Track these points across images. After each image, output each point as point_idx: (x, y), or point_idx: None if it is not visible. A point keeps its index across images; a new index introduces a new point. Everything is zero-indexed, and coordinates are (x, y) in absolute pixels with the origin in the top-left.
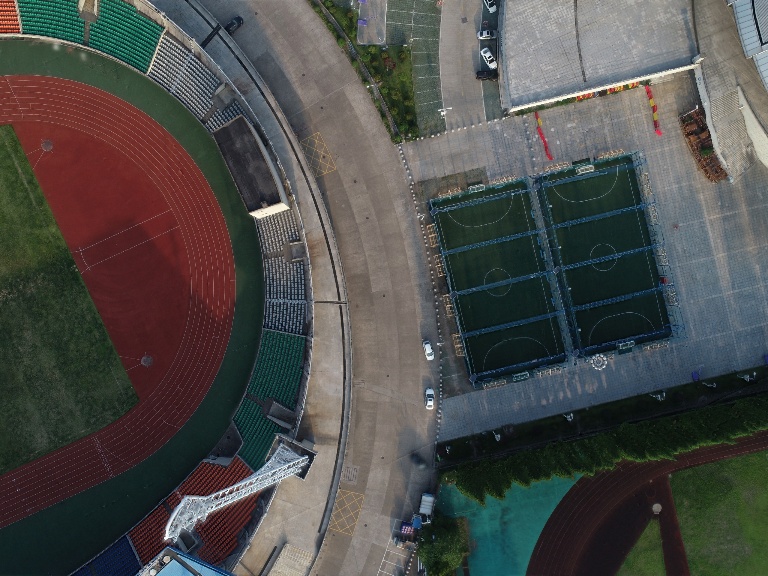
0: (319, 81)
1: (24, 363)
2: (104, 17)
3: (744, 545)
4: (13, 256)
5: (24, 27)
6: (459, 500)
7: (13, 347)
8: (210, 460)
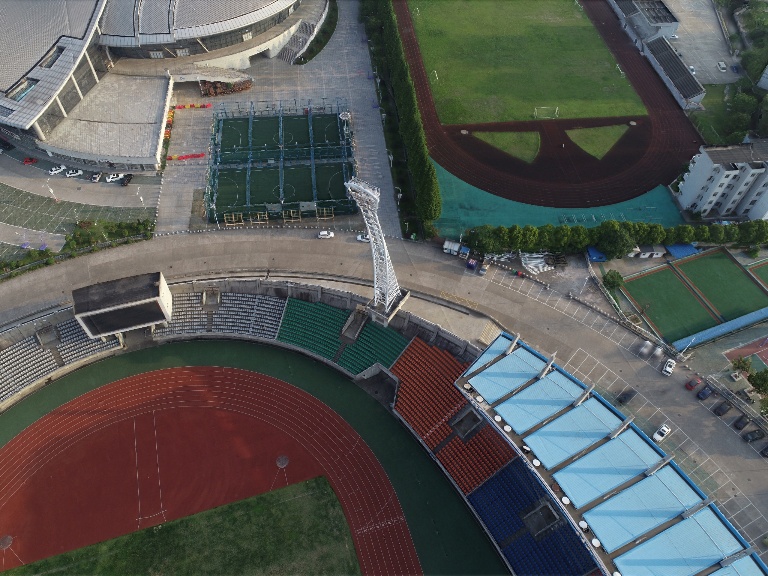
0: (74, 282)
1: None
2: None
3: (490, 98)
4: None
5: None
6: (451, 232)
7: None
8: (393, 402)
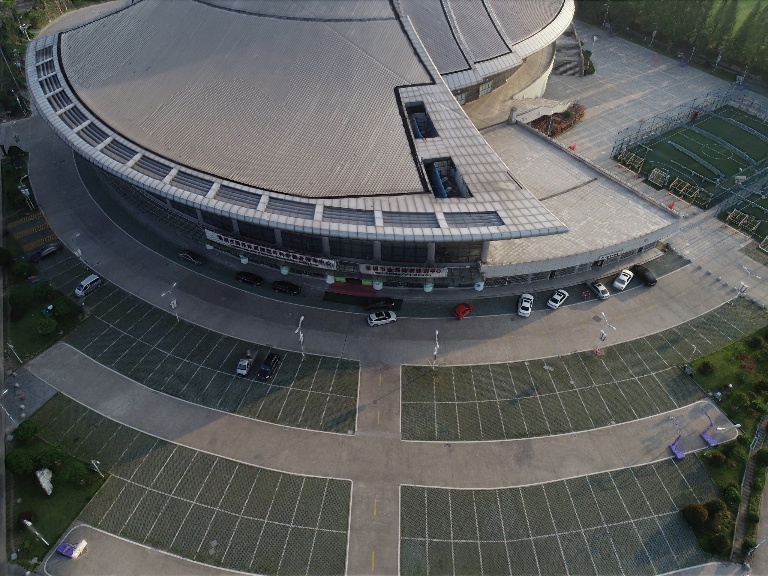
0: None
1: None
2: None
3: None
4: None
5: None
6: None
7: None
8: None
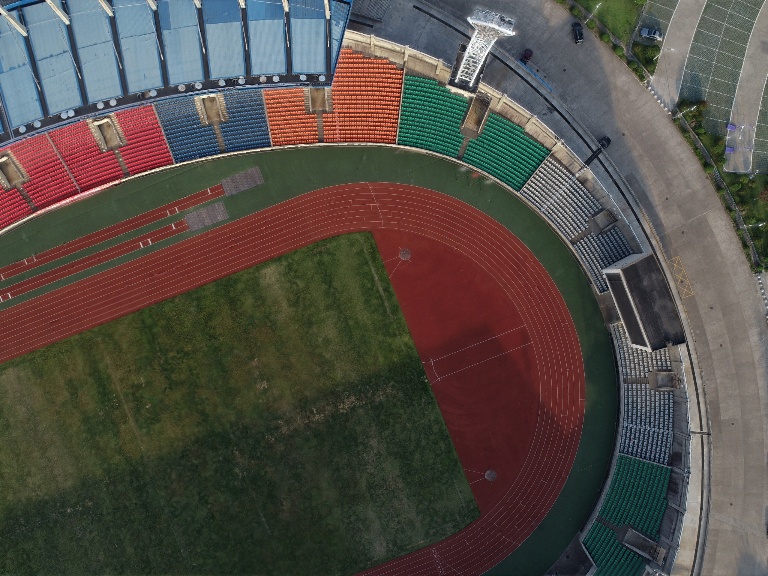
0: (682, 206)
1: (368, 470)
2: (487, 135)
3: None
4: (364, 363)
5: (400, 138)
6: None
7: (358, 454)
8: None
